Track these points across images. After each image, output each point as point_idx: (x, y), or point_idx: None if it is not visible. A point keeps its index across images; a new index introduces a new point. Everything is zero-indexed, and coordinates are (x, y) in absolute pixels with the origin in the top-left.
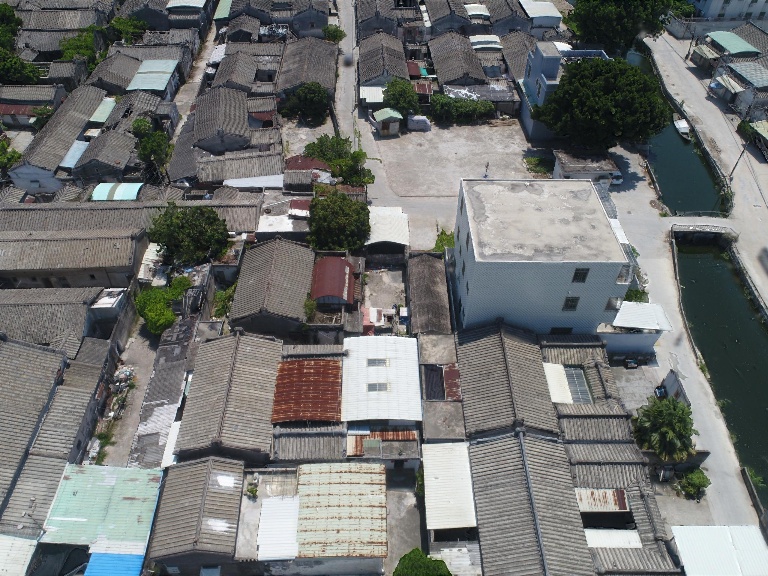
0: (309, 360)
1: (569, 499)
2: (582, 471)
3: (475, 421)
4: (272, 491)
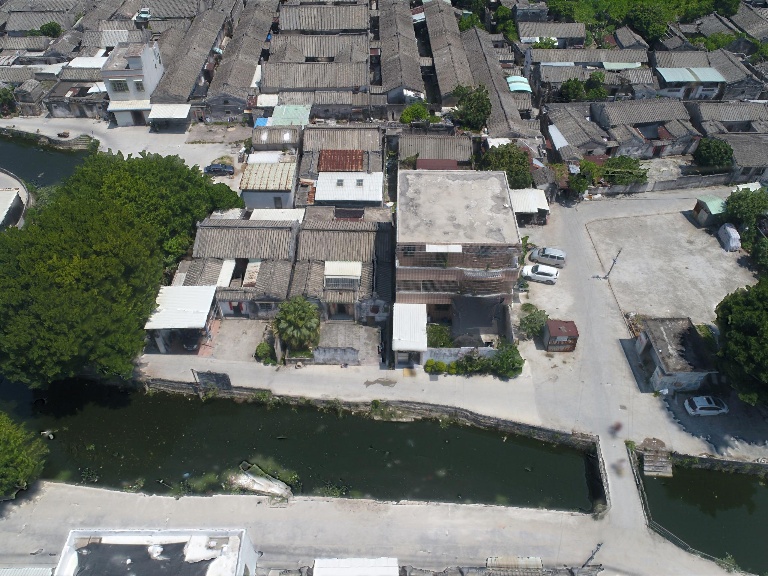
0: (362, 157)
1: (250, 253)
2: (269, 265)
3: (313, 222)
4: (286, 159)
